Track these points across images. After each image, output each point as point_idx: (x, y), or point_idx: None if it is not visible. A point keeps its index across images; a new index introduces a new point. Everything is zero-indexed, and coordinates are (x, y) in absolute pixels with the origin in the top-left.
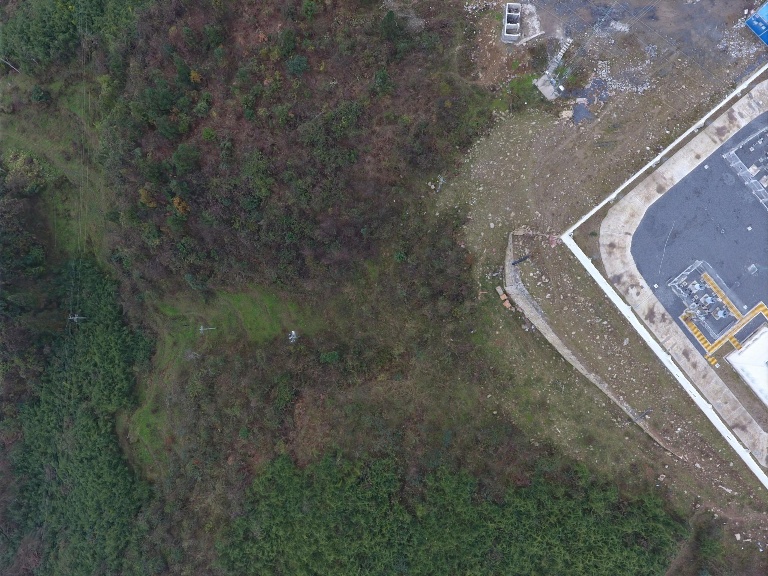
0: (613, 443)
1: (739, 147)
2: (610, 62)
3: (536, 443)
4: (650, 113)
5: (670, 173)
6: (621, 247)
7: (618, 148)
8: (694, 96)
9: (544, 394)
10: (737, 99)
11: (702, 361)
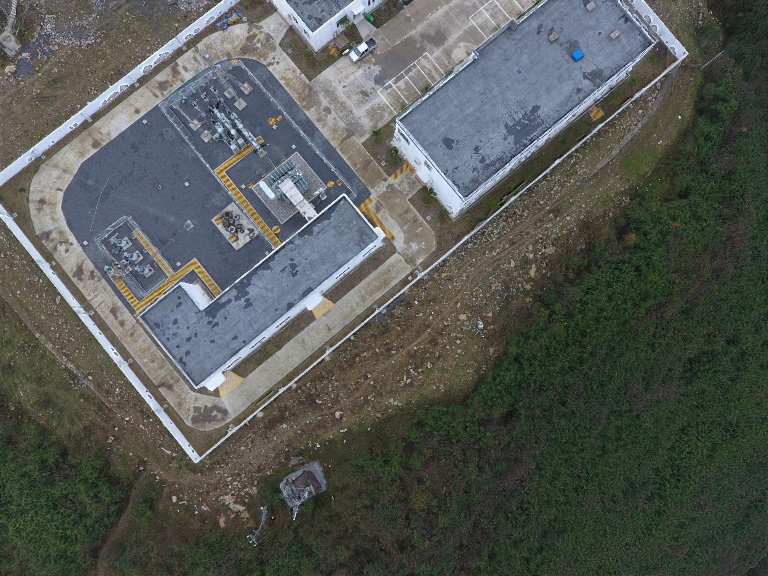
0: (69, 405)
1: (181, 101)
2: (56, 16)
3: (12, 407)
4: (93, 67)
5: (107, 128)
6: (51, 203)
7: (57, 103)
8: (140, 50)
9: (12, 357)
10: (182, 53)
11: (130, 319)
